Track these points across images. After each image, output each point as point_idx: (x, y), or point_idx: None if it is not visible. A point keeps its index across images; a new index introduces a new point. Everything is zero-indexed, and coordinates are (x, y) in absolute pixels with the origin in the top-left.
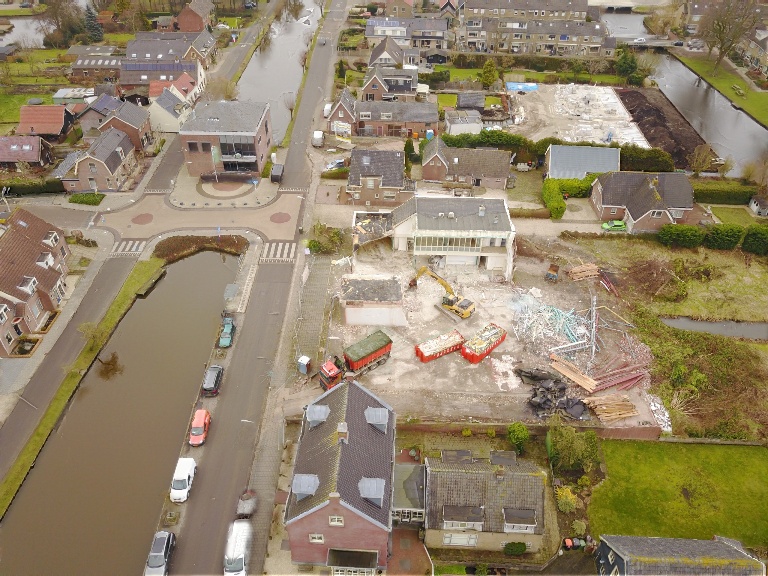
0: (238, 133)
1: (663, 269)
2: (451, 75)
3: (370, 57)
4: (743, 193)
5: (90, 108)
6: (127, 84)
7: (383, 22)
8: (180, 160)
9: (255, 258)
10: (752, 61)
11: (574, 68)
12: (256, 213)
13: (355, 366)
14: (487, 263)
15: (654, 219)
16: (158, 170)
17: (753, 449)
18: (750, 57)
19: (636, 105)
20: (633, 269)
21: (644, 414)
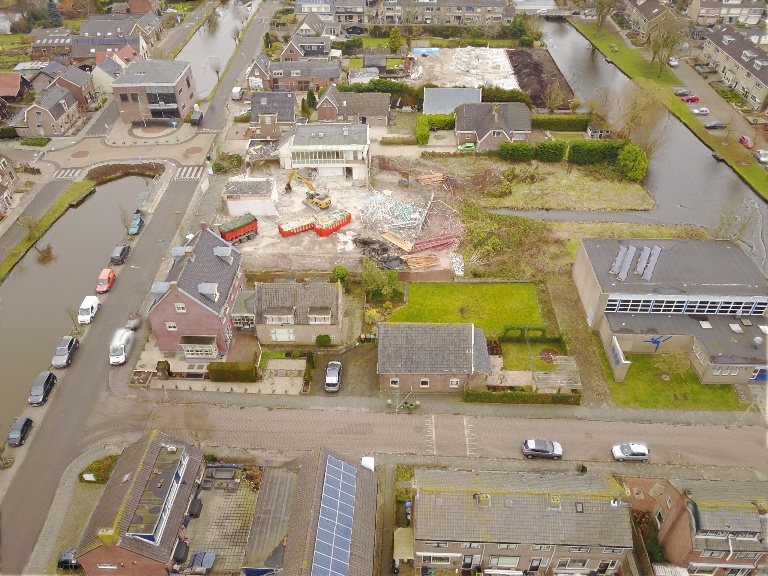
0: (160, 84)
1: (494, 174)
2: (363, 42)
3: (295, 30)
4: (580, 121)
5: (40, 72)
6: (78, 57)
7: (310, 0)
8: (118, 113)
9: (168, 178)
10: (634, 24)
11: (472, 33)
12: (175, 148)
13: (227, 237)
14: (353, 174)
15: (495, 139)
16: (98, 121)
17: (523, 285)
18: (633, 21)
19: (520, 61)
20: (474, 177)
21: (446, 265)
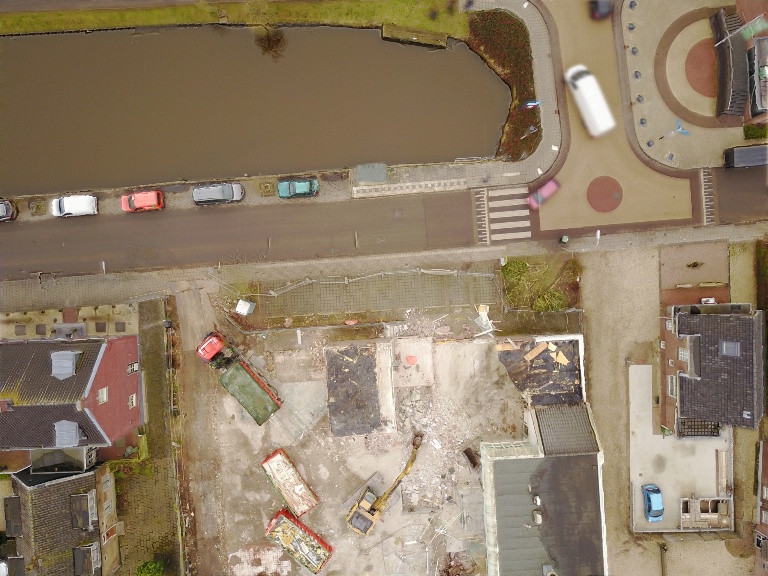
0: None
1: None
2: None
3: None
4: None
5: None
6: None
7: None
8: None
9: (483, 180)
10: None
11: None
12: (616, 147)
13: None
14: None
15: None
16: None
17: None
18: None
19: None
20: None
21: None
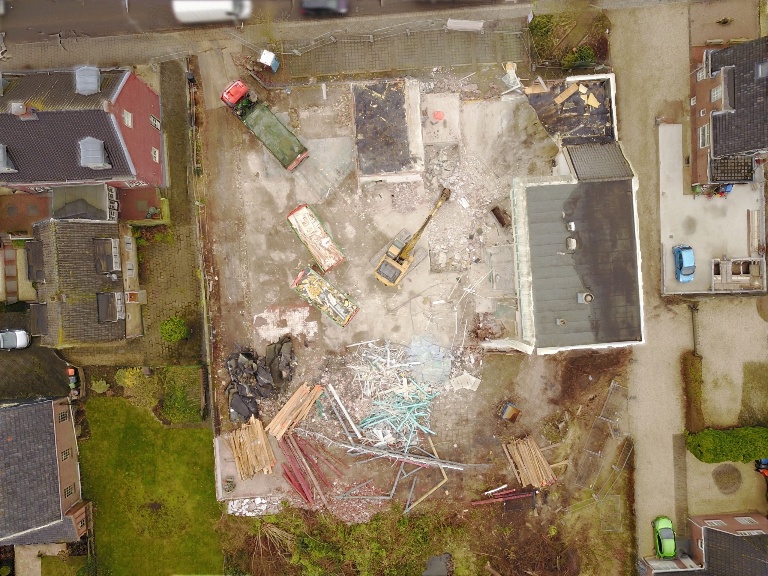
0: None
1: None
2: None
3: None
4: None
5: None
6: None
7: None
8: None
9: None
10: None
11: None
12: None
13: None
14: None
15: None
16: None
17: None
18: None
19: None
20: (553, 543)
21: (247, 487)
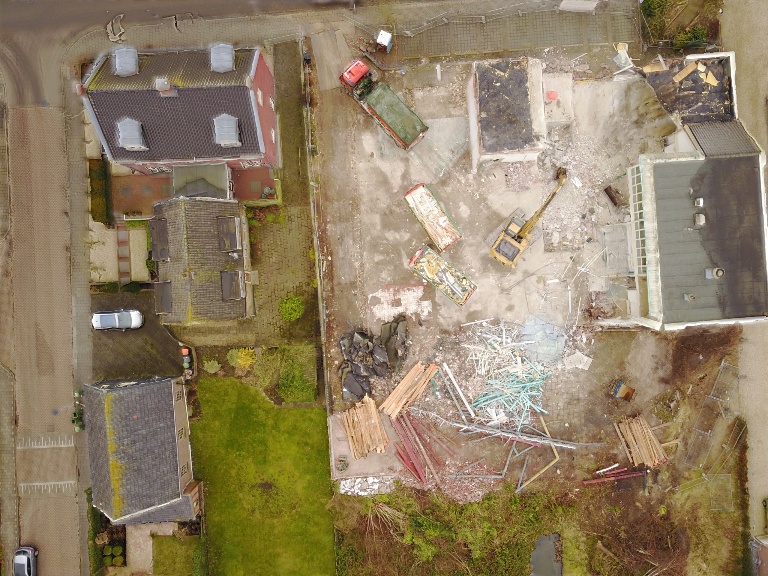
0: None
1: (653, 567)
2: None
3: None
4: None
5: None
6: None
7: None
8: None
9: None
10: None
11: None
12: None
13: None
14: (634, 289)
15: None
16: None
17: None
18: None
19: None
20: (663, 523)
21: (359, 466)
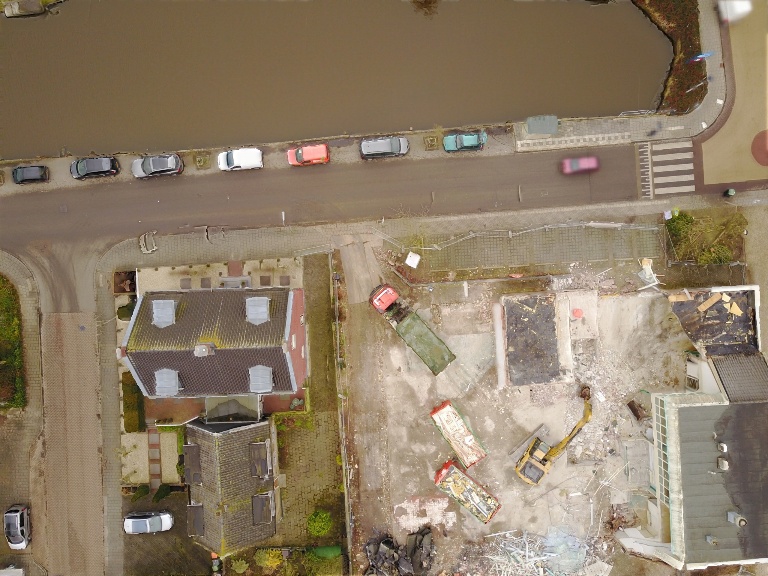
0: None
1: None
2: None
3: None
4: None
5: None
6: None
7: None
8: None
9: (648, 134)
10: None
11: None
12: None
13: None
14: (655, 504)
15: None
16: None
17: None
18: None
19: None
20: None
21: None
